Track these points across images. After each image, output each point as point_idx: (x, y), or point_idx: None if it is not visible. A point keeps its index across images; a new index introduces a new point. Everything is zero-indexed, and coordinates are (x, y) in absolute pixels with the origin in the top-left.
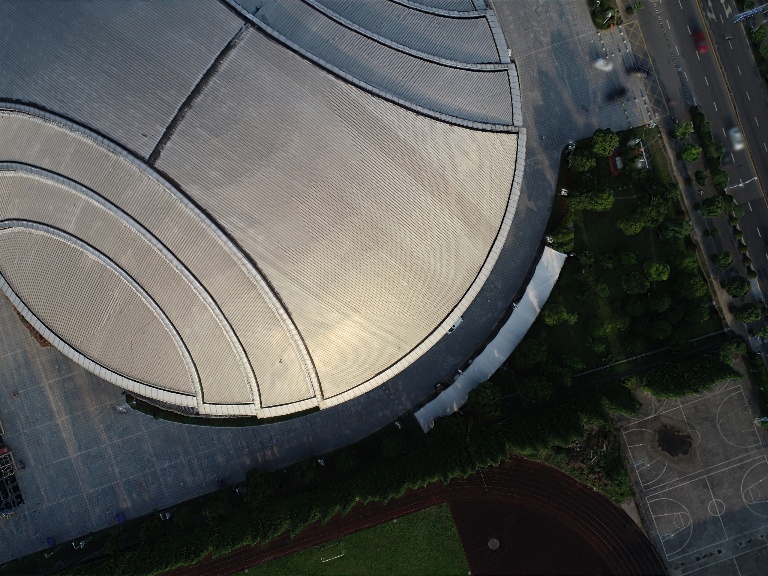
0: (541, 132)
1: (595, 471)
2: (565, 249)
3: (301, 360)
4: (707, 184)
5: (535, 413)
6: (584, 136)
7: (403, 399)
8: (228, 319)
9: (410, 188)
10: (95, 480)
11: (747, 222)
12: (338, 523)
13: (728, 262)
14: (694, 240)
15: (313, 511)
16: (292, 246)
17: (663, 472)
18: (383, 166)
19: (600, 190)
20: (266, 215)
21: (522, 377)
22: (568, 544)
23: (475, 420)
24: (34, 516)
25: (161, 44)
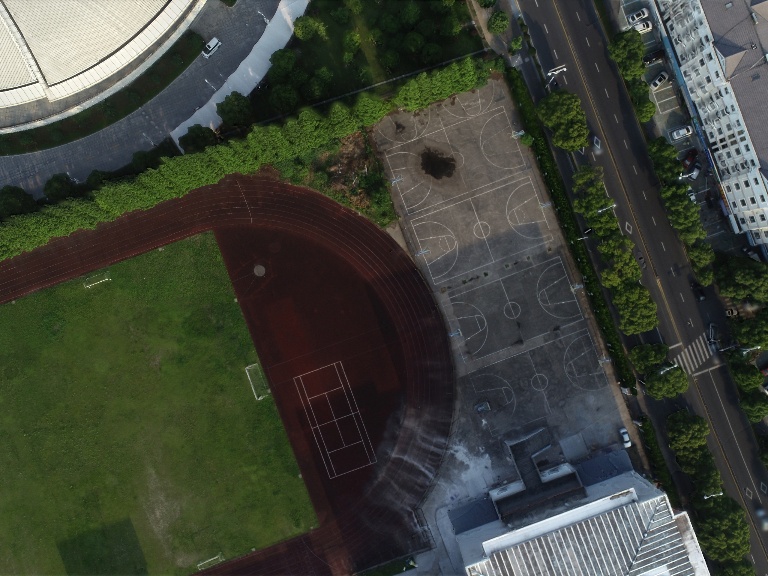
0: None
1: (357, 193)
2: None
3: (9, 30)
4: None
5: None
6: None
7: (164, 125)
8: None
9: None
10: None
11: None
12: (103, 252)
13: None
14: None
15: (50, 209)
16: None
17: (427, 195)
18: None
19: None
20: None
21: None
22: (334, 269)
23: None
24: None
25: None
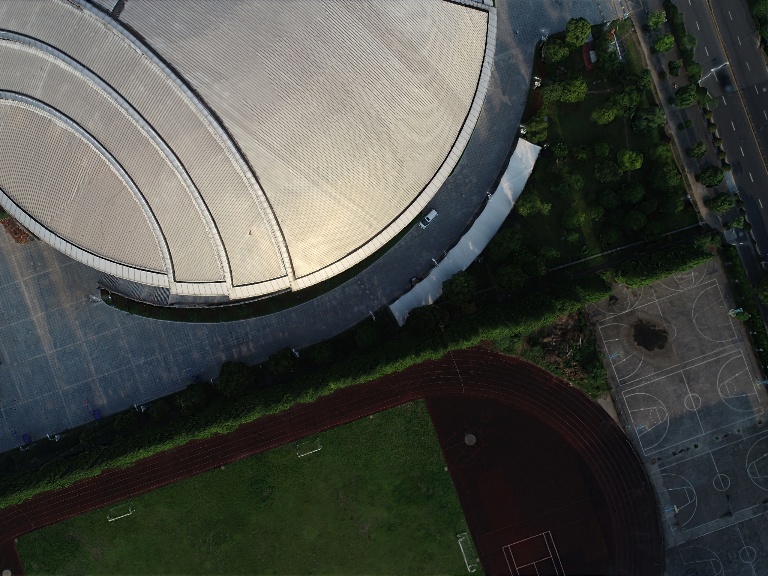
0: (515, 26)
1: (571, 365)
2: (538, 138)
3: (271, 233)
4: (681, 76)
5: (510, 303)
6: (558, 30)
7: (378, 294)
8: (196, 184)
9: (377, 51)
10: (71, 377)
11: (721, 116)
12: (314, 419)
13: (701, 151)
14: (668, 134)
15: (286, 395)
16: (258, 104)
17: (639, 367)
18: (349, 26)
19: (573, 78)
20: (231, 70)
21: (497, 269)
22: (544, 439)
23: (451, 315)
24: (10, 413)
25: None
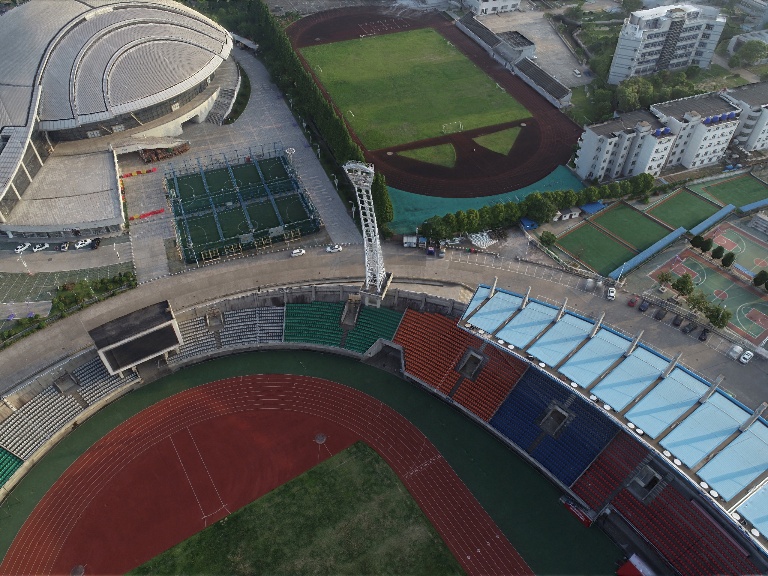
0: None
1: None
2: None
3: None
4: None
5: None
6: None
7: None
8: None
9: None
10: (273, 133)
11: None
12: None
13: None
14: None
15: None
16: None
17: None
18: None
19: None
20: None
21: None
22: None
23: None
24: None
25: (44, 5)
